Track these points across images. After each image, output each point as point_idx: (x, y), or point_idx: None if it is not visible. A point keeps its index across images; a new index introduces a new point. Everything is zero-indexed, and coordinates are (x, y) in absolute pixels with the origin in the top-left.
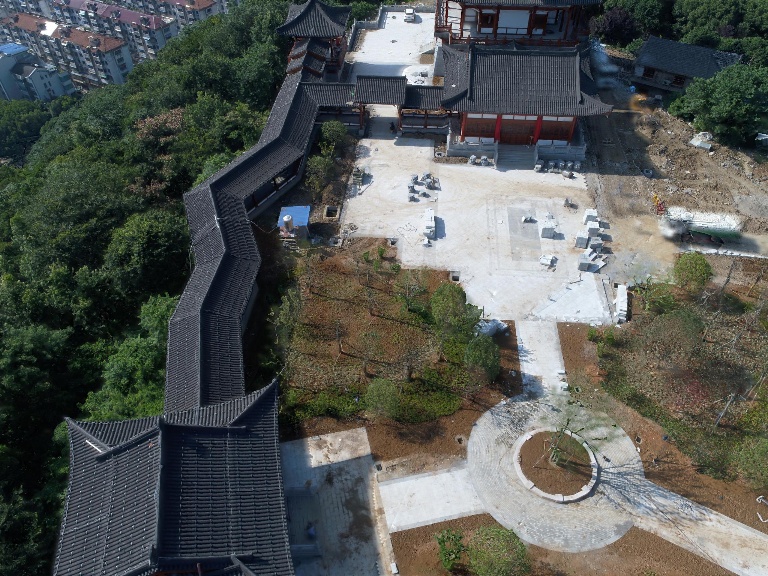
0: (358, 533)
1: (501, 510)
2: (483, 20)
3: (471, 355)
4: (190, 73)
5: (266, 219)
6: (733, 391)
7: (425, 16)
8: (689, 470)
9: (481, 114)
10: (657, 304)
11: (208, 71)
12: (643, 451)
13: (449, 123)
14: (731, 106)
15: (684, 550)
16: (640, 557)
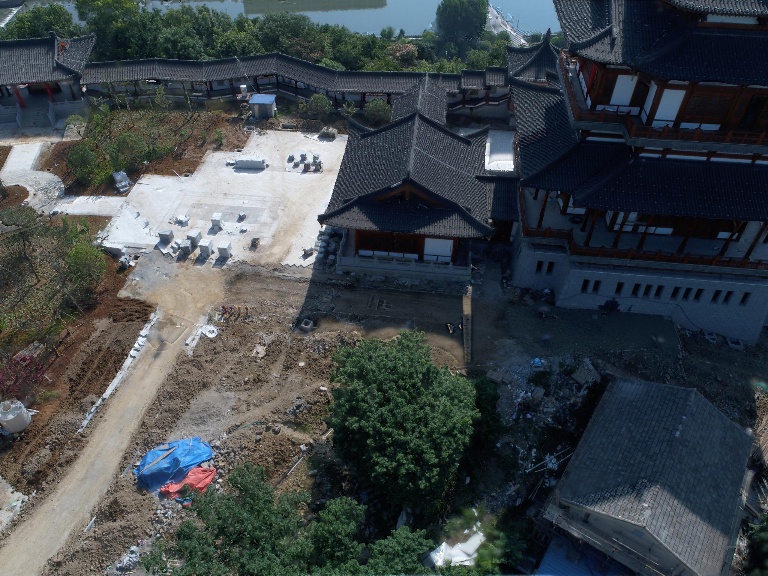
0: (21, 137)
1: None
2: None
3: None
4: None
5: (287, 103)
6: None
7: None
8: None
9: None
10: None
11: None
12: None
13: None
14: None
15: None
16: None
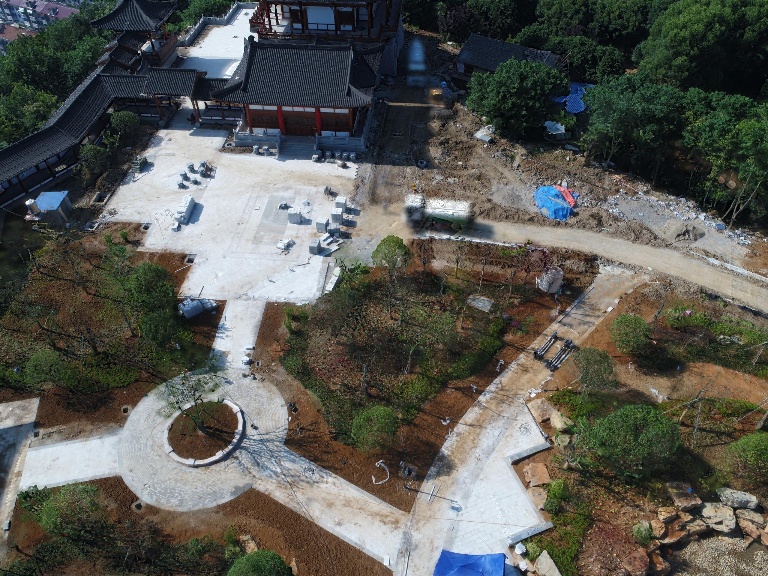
0: None
1: (133, 473)
2: (293, 16)
3: (144, 329)
4: (16, 65)
5: None
6: (397, 365)
7: None
8: (325, 437)
9: (262, 105)
10: (357, 284)
11: (38, 64)
12: (293, 420)
13: (241, 115)
14: (497, 100)
15: (288, 509)
16: (242, 515)
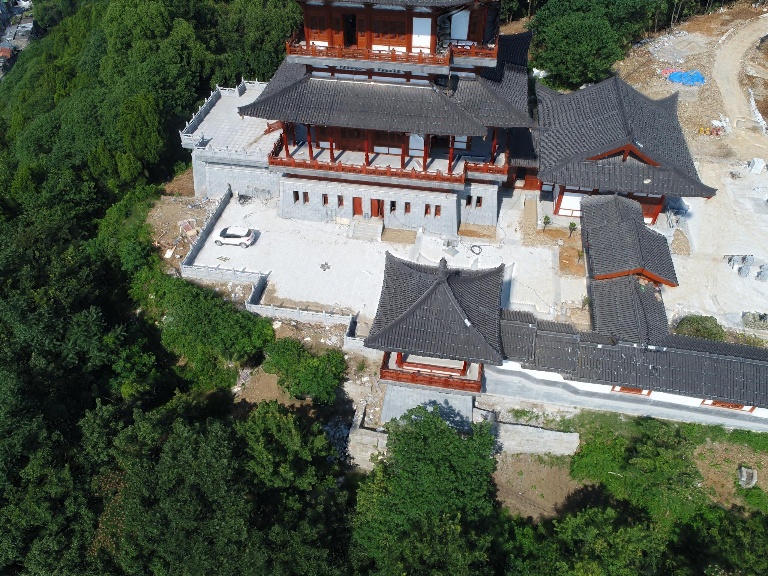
0: None
1: None
2: None
3: None
4: None
5: None
6: None
7: (232, 224)
8: None
9: None
10: None
11: None
12: None
13: None
14: None
15: None
16: None
